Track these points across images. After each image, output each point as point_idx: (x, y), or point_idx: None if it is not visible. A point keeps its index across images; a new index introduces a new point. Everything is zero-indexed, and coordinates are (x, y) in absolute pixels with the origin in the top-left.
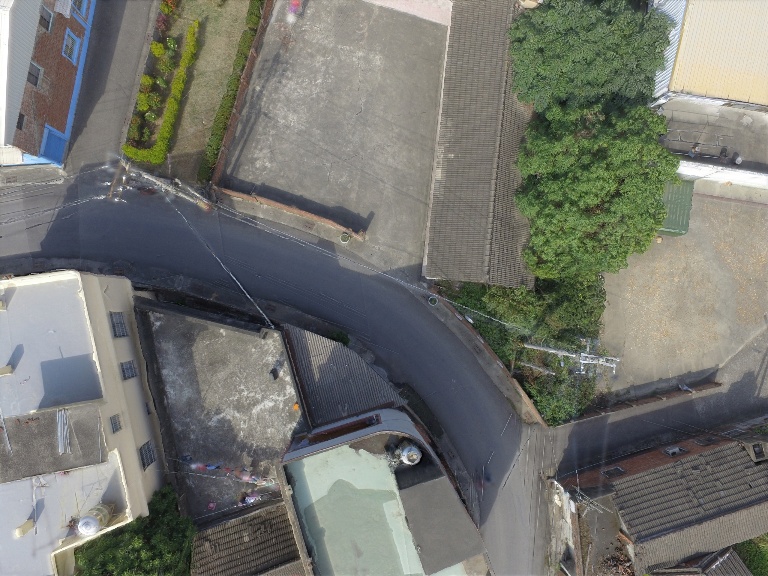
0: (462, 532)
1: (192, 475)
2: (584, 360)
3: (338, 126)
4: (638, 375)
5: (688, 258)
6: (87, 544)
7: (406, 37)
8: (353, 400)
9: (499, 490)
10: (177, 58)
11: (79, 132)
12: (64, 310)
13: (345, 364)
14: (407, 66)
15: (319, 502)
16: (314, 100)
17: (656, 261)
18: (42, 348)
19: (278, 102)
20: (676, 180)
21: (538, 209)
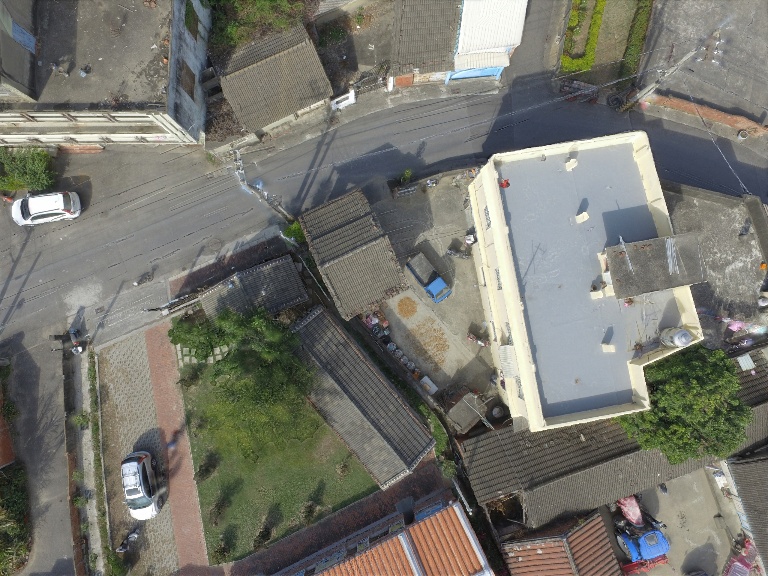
0: None
1: None
2: None
3: (732, 36)
4: None
5: None
6: (655, 363)
7: None
8: None
9: None
10: None
11: None
12: (617, 170)
13: None
14: None
15: None
16: (710, 14)
17: None
18: (602, 201)
19: (678, 17)
20: None
21: None
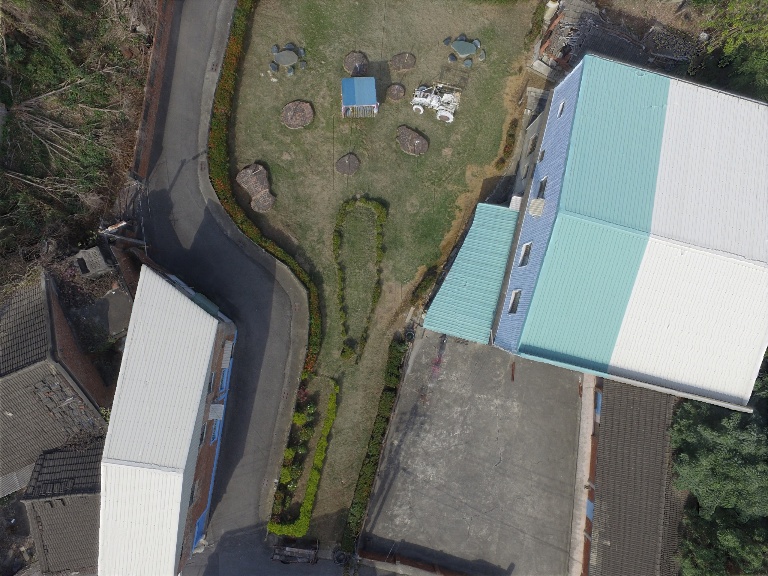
0: None
1: None
2: None
3: (477, 478)
4: None
5: None
6: None
7: (543, 381)
8: None
9: None
10: (315, 416)
11: (219, 499)
12: None
13: None
14: (545, 411)
15: None
16: (453, 452)
17: None
18: None
19: (417, 456)
20: None
21: None
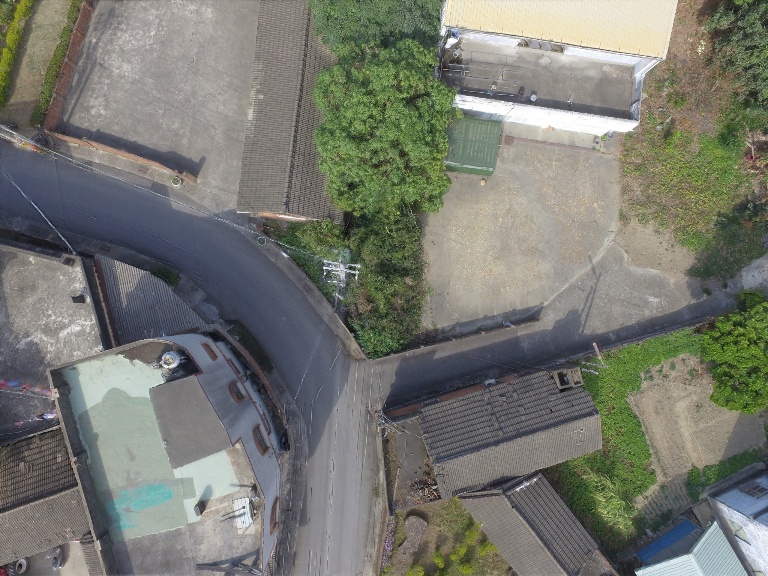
0: (208, 428)
1: None
2: (326, 266)
3: (171, 75)
4: (463, 312)
5: (512, 200)
6: None
7: None
8: (159, 326)
9: (327, 423)
10: None
11: None
12: None
13: (152, 292)
14: (238, 19)
15: (93, 409)
16: (148, 51)
17: (480, 203)
18: None
19: (113, 53)
20: (458, 112)
21: (322, 138)
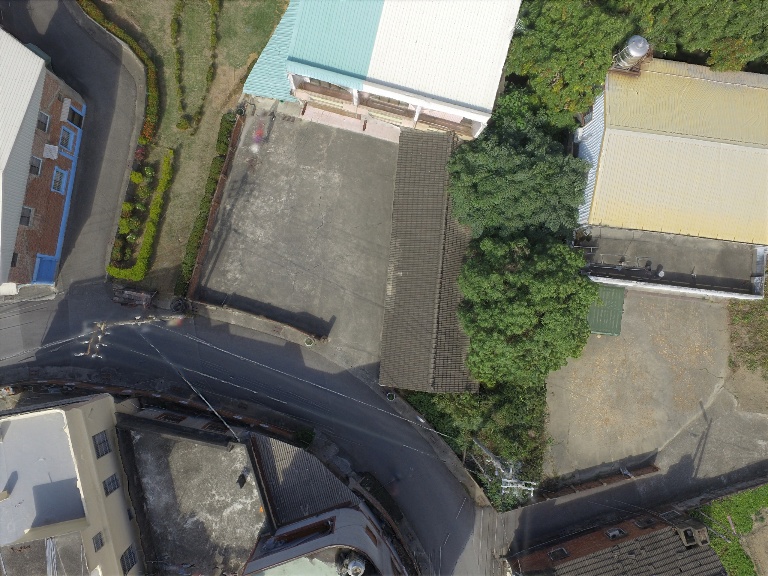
0: None
1: (170, 573)
2: (505, 485)
3: (301, 239)
4: (582, 460)
5: (627, 351)
6: None
7: (362, 155)
8: (313, 501)
9: (455, 569)
10: (155, 182)
11: (68, 253)
12: (52, 440)
13: (306, 468)
14: (363, 182)
15: None
16: (279, 216)
17: (597, 354)
18: (34, 474)
19: (247, 219)
20: (599, 301)
21: (473, 332)
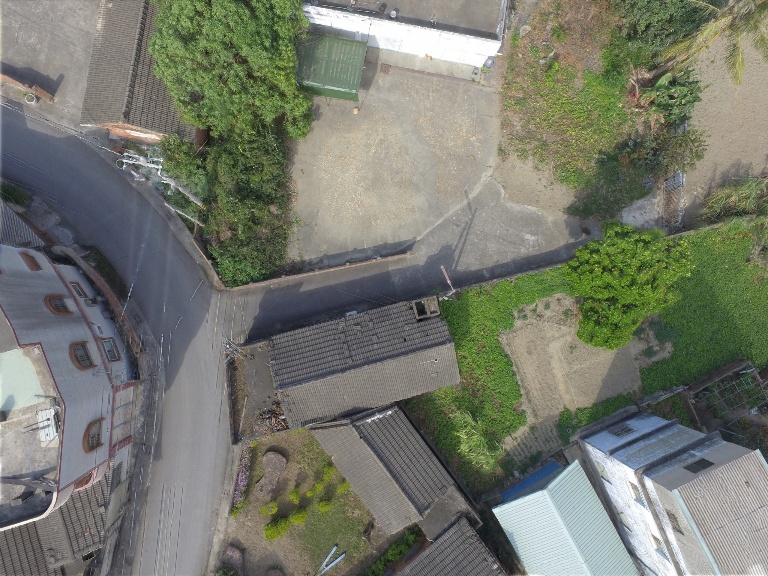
0: None
1: None
2: (126, 159)
3: None
4: (332, 244)
5: (386, 130)
6: None
7: None
8: None
9: (186, 355)
10: None
11: None
12: None
13: None
14: None
15: None
16: None
17: (352, 132)
18: None
19: None
20: (303, 19)
21: None
